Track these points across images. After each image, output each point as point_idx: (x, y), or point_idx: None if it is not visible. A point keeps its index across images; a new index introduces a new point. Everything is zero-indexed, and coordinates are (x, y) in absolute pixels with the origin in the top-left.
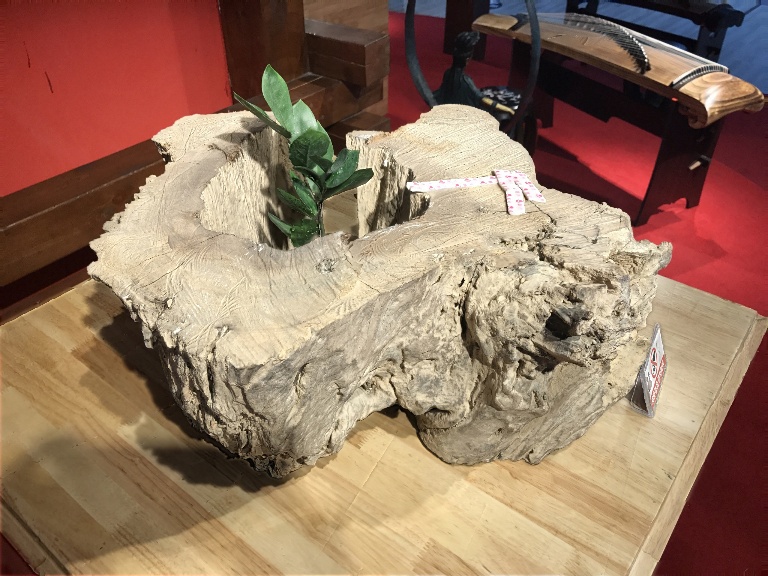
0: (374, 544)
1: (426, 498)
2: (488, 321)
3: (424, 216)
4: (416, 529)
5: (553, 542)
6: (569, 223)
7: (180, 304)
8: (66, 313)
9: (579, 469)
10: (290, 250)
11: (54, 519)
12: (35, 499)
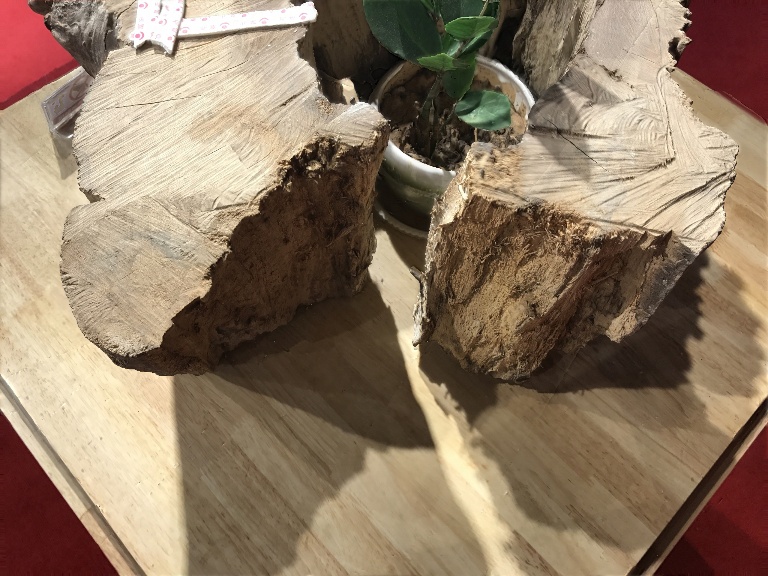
0: None
1: None
2: None
3: None
4: None
5: None
6: None
7: None
8: None
9: None
10: None
11: None
12: None
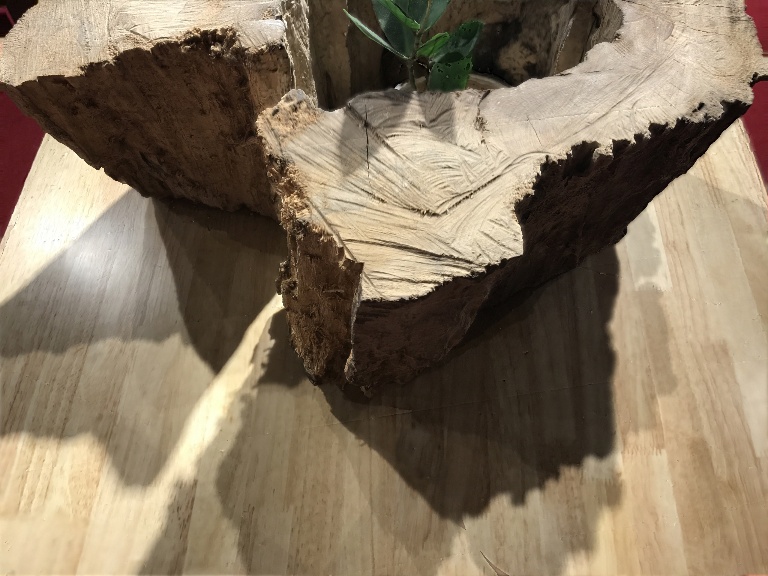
0: None
1: None
2: None
3: None
4: None
5: None
6: None
7: None
8: (630, 554)
9: None
10: None
11: (763, 251)
12: None
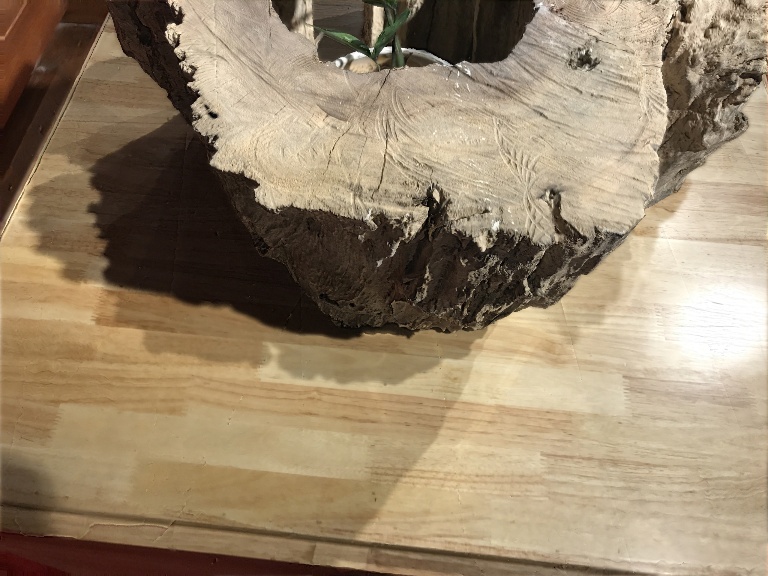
0: (616, 337)
1: (620, 271)
2: (708, 56)
3: None
4: (637, 303)
5: (745, 251)
6: None
7: (455, 190)
8: (26, 280)
9: (713, 176)
10: (508, 57)
11: (292, 506)
12: (246, 501)
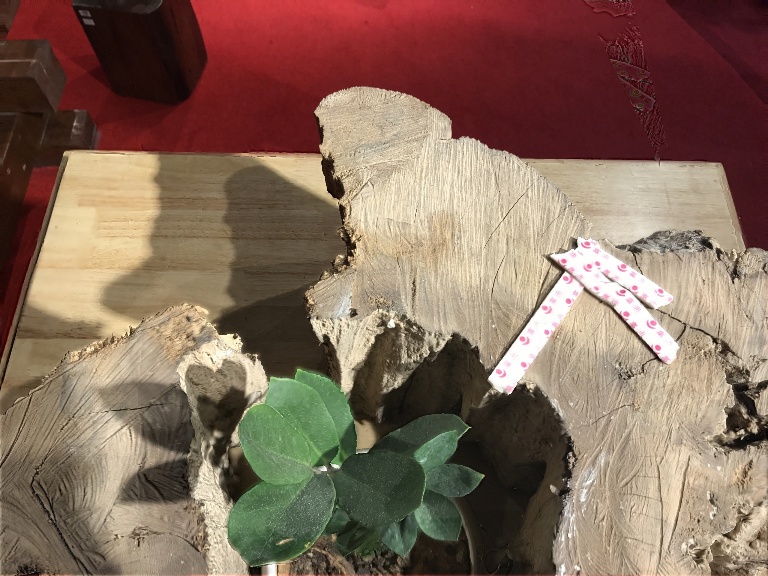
0: None
1: None
2: None
3: (577, 447)
4: None
5: None
6: (742, 337)
7: None
8: None
9: None
10: None
11: None
12: None
